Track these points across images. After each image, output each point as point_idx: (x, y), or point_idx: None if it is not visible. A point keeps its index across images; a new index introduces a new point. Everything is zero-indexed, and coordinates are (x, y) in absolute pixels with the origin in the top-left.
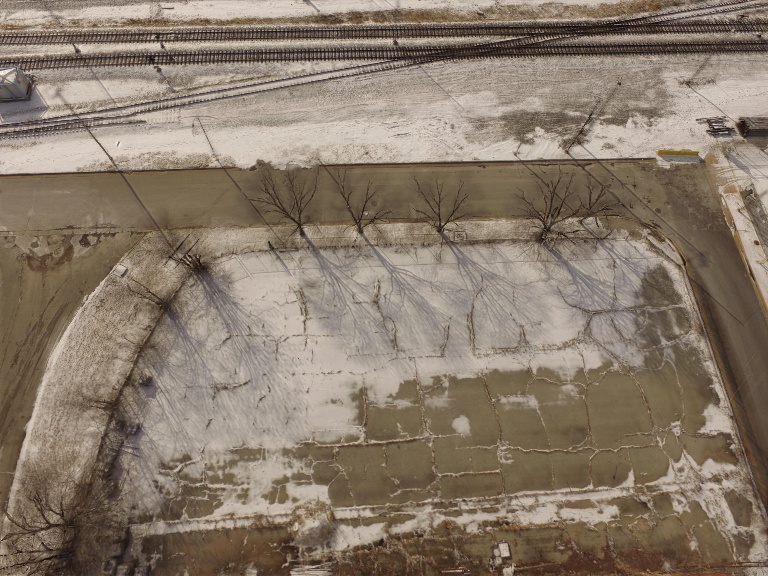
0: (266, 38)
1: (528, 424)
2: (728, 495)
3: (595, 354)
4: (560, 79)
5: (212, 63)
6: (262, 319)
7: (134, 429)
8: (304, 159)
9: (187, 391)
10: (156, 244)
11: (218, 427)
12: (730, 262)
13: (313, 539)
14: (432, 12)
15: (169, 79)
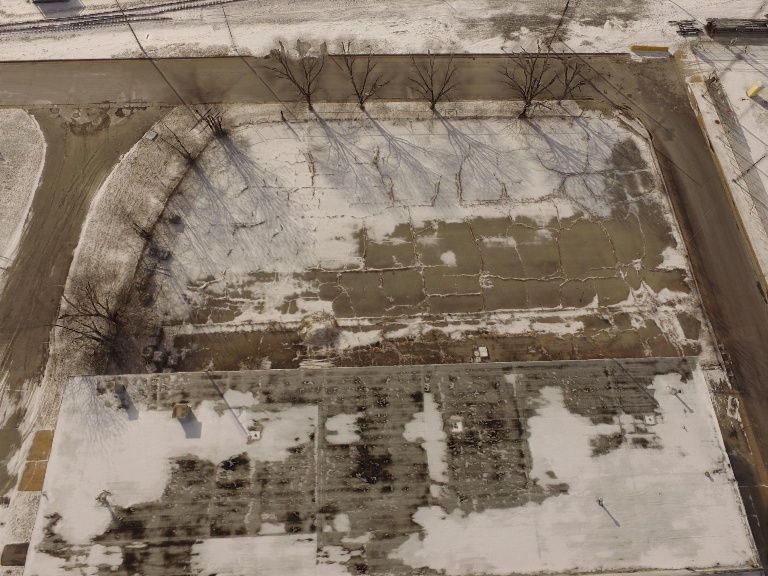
0: None
1: (507, 258)
2: (680, 316)
3: (568, 206)
4: None
5: None
6: (275, 174)
7: (166, 254)
8: (313, 50)
9: (211, 228)
10: (182, 115)
11: (238, 255)
12: (692, 137)
13: (319, 339)
14: None
15: None
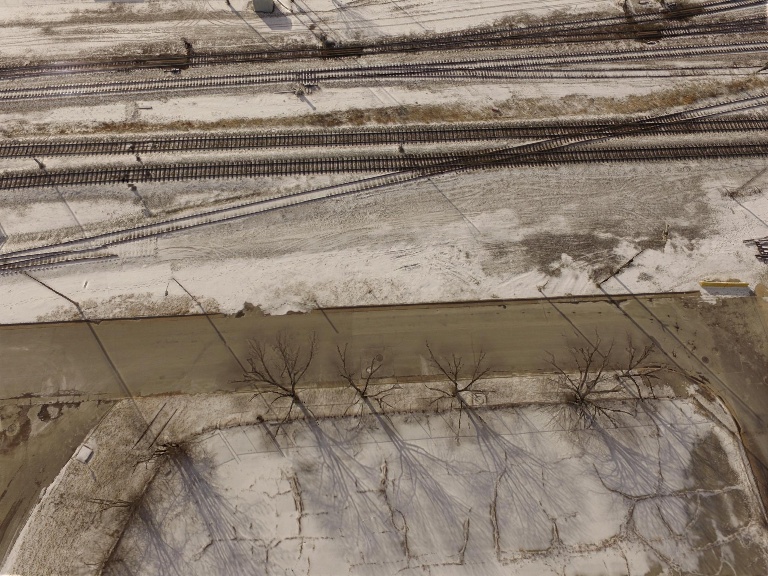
0: (255, 146)
1: None
2: None
3: (641, 556)
4: (587, 192)
5: (194, 179)
6: (250, 517)
7: None
8: (298, 301)
9: None
10: (127, 417)
11: None
12: None
13: None
14: (441, 108)
15: (145, 199)
